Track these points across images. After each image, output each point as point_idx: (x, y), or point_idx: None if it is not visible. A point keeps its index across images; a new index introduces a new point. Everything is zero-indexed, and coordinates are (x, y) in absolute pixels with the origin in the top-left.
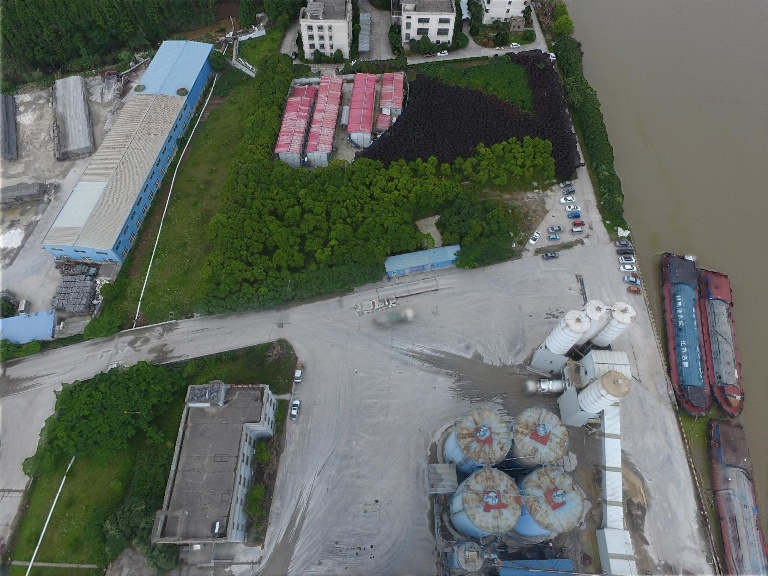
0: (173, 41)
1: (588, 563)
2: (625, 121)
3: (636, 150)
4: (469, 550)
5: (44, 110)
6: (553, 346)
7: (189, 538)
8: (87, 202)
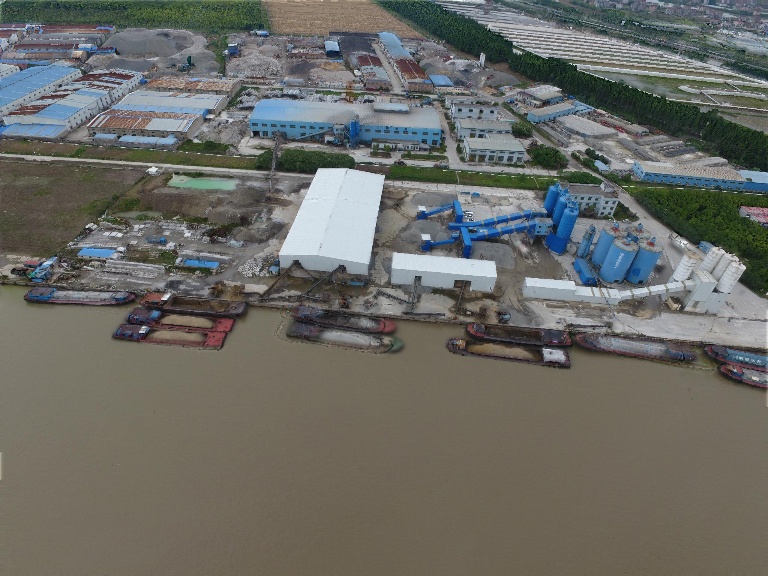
0: None
1: None
2: None
3: None
4: None
5: (698, 158)
6: None
7: None
8: None
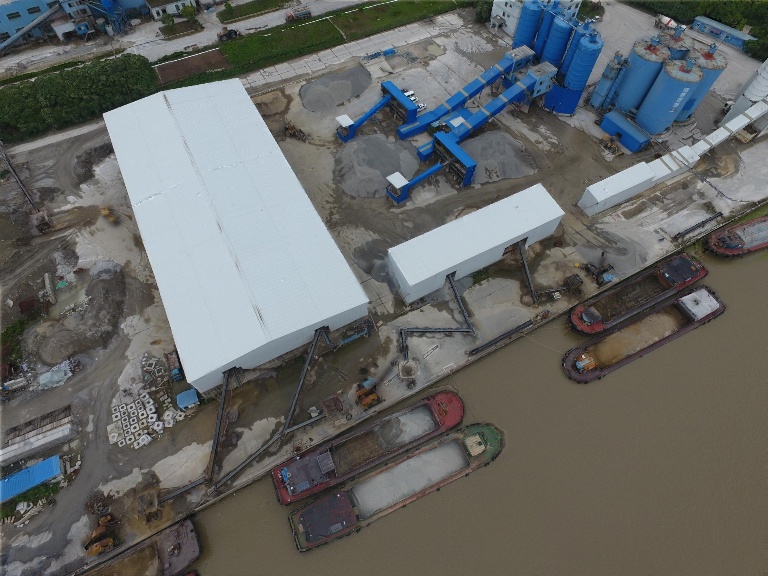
0: None
1: (659, 154)
2: None
3: None
4: None
5: None
6: (763, 64)
7: None
8: None
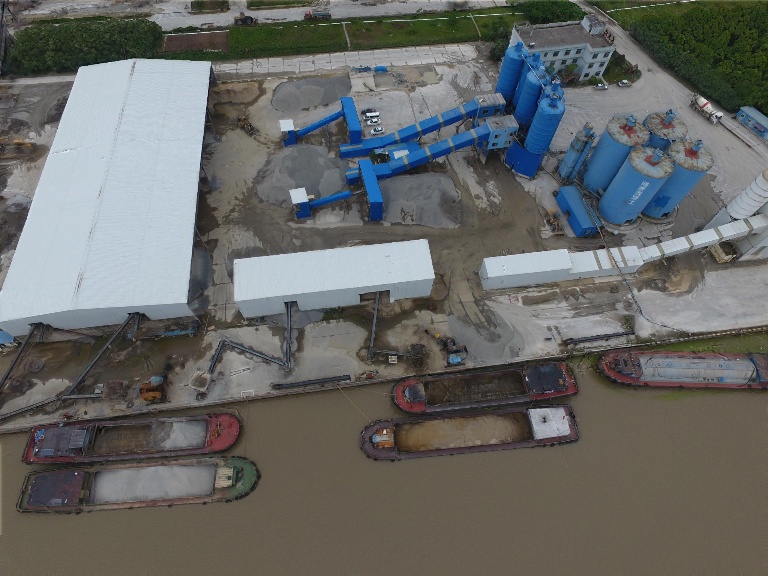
0: None
1: (603, 246)
2: None
3: None
4: None
5: None
6: None
7: None
8: None
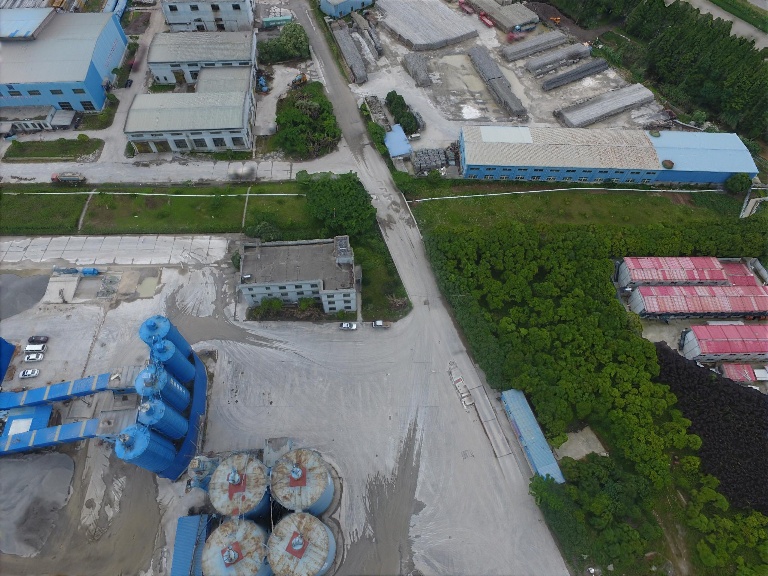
0: (740, 140)
1: None
2: None
3: None
4: (200, 461)
5: (604, 89)
6: None
7: (243, 262)
8: (508, 137)
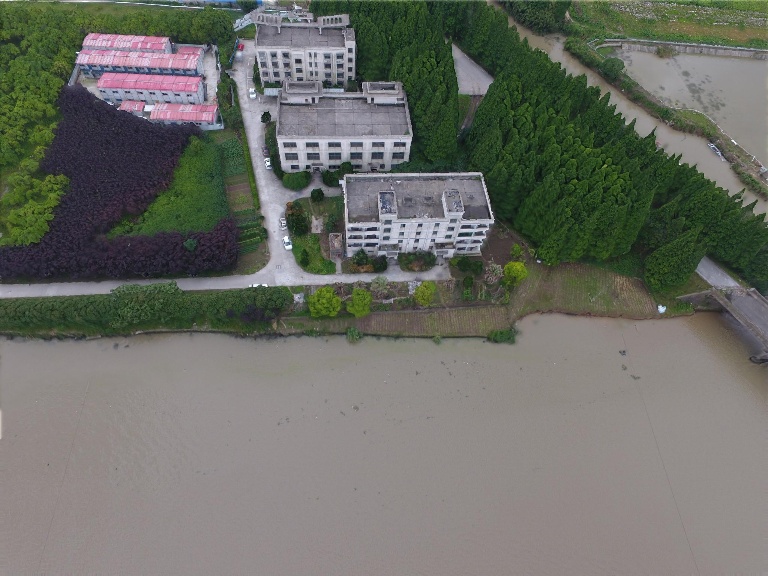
0: None
1: None
2: (99, 376)
3: (27, 377)
4: None
5: None
6: None
7: None
8: None
